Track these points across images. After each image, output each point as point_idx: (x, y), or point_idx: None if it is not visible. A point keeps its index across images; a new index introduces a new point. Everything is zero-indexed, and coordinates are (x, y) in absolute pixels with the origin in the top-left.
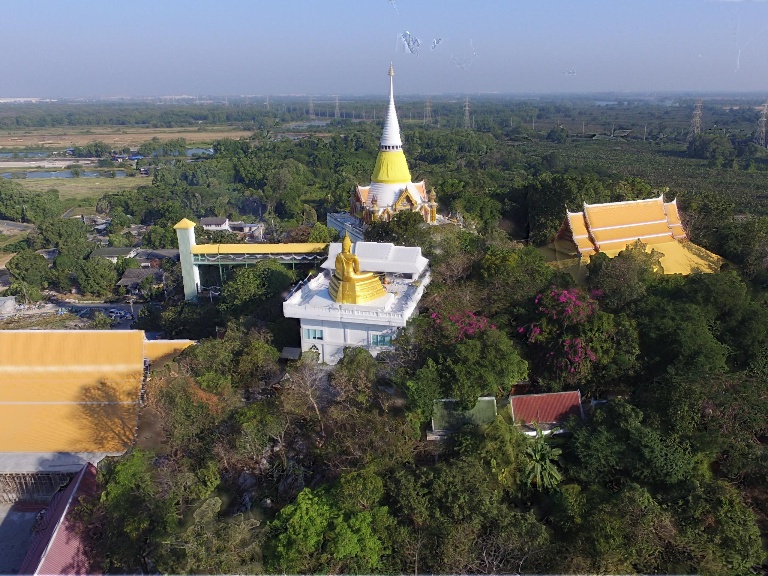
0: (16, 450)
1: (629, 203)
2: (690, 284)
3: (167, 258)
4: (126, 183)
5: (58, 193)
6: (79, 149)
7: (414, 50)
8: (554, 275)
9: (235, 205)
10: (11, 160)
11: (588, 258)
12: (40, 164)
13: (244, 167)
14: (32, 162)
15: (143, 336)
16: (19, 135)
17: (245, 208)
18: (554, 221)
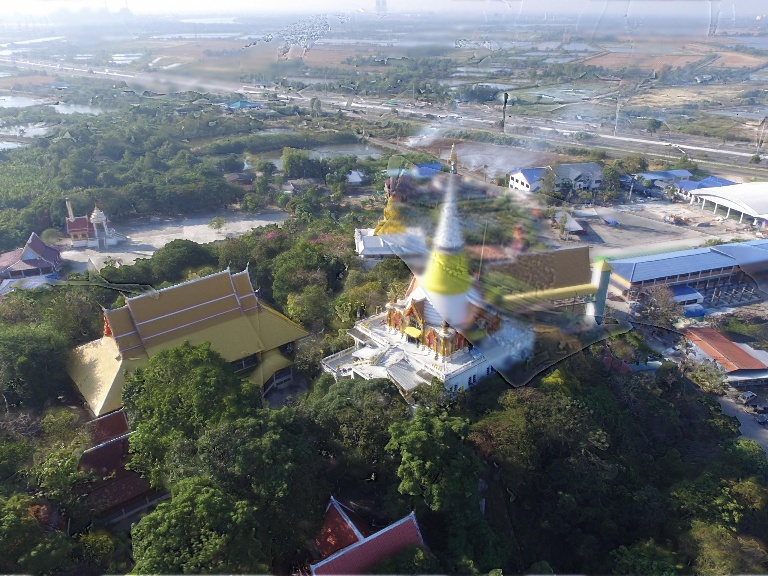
0: None
1: (175, 287)
2: (197, 245)
3: None
4: None
5: None
6: None
7: None
8: None
9: None
10: None
11: None
12: None
13: None
14: None
15: None
16: None
17: None
18: None
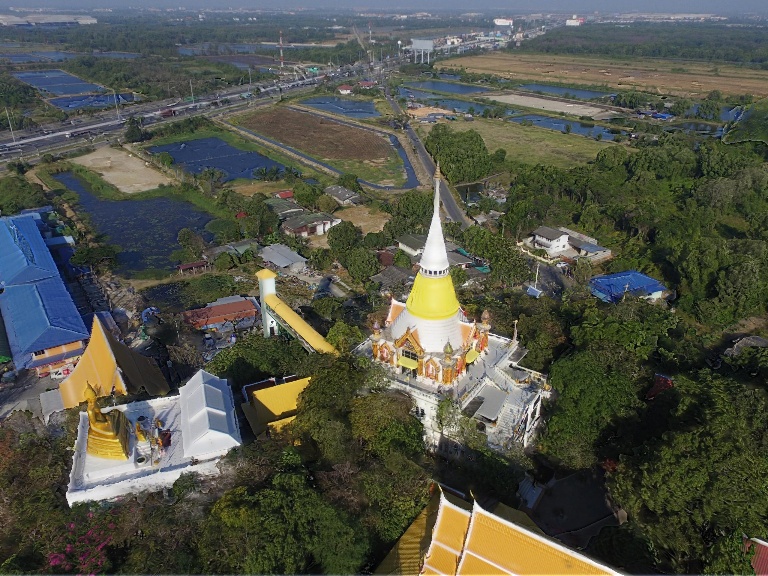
0: (64, 400)
1: (575, 557)
2: None
3: None
4: (592, 151)
5: (505, 154)
6: (621, 96)
7: (21, 247)
8: (260, 574)
9: (611, 217)
10: (559, 99)
11: None
12: (573, 108)
13: (709, 162)
14: (572, 104)
15: (116, 368)
16: (615, 67)
17: (622, 223)
18: (625, 481)
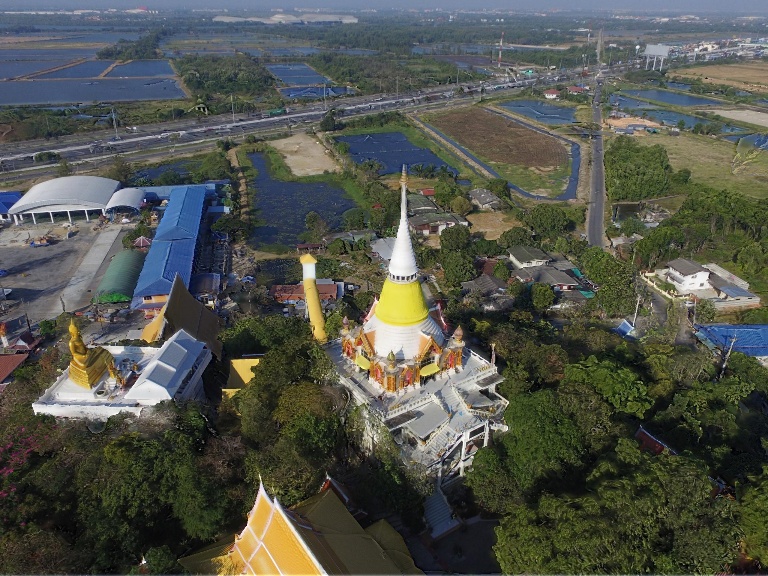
0: None
1: None
2: None
3: (519, 281)
4: None
5: (690, 175)
6: None
7: None
8: (107, 506)
9: None
10: None
11: (230, 565)
12: None
13: None
14: None
15: (164, 318)
16: None
17: None
18: None
